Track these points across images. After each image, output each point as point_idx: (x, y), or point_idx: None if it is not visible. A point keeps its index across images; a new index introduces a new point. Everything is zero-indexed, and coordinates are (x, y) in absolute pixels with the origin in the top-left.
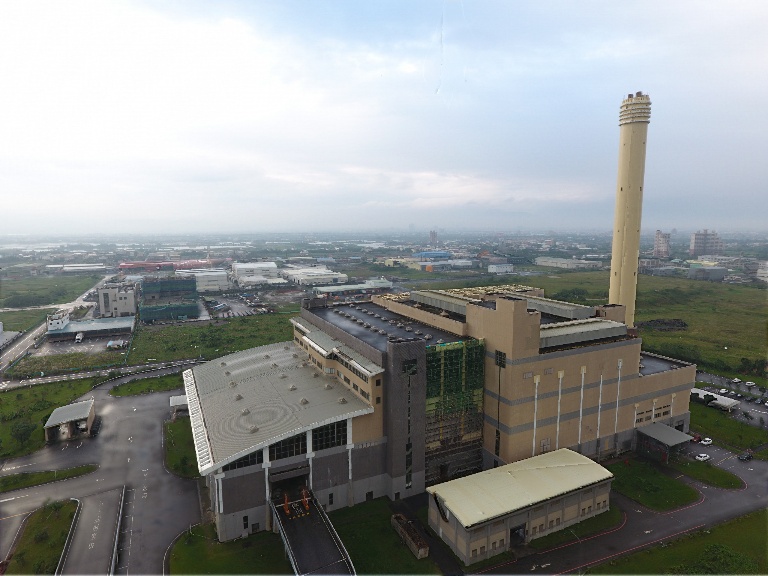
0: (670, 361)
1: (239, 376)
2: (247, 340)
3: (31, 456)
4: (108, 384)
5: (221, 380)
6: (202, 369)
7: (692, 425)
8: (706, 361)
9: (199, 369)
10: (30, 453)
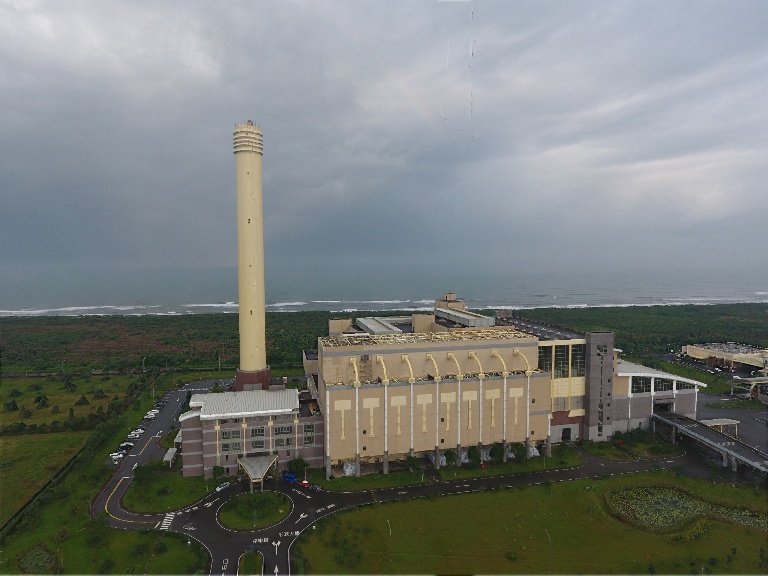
0: None
1: None
2: None
3: None
4: None
5: None
6: None
7: None
8: (118, 424)
9: None
10: None
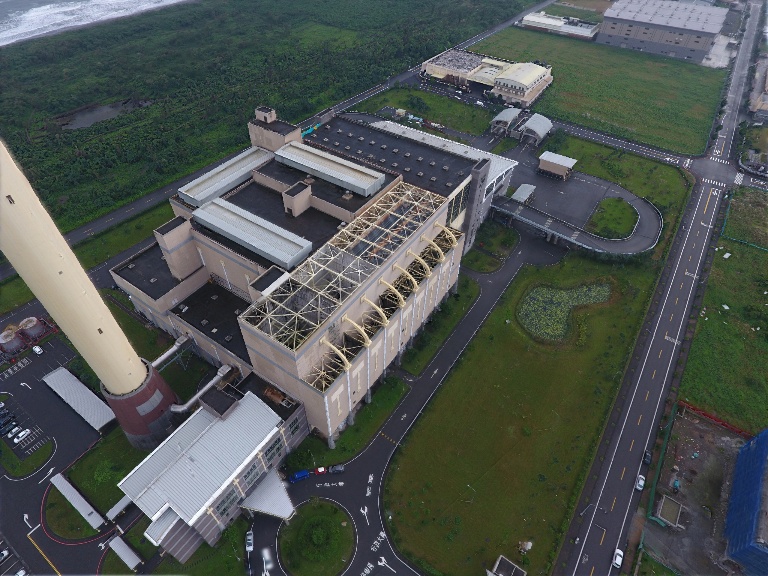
0: (127, 279)
1: (454, 151)
2: (766, 358)
3: (532, 154)
4: (645, 205)
5: (462, 150)
6: (502, 160)
7: (127, 323)
8: None
9: (506, 161)
10: (536, 155)
